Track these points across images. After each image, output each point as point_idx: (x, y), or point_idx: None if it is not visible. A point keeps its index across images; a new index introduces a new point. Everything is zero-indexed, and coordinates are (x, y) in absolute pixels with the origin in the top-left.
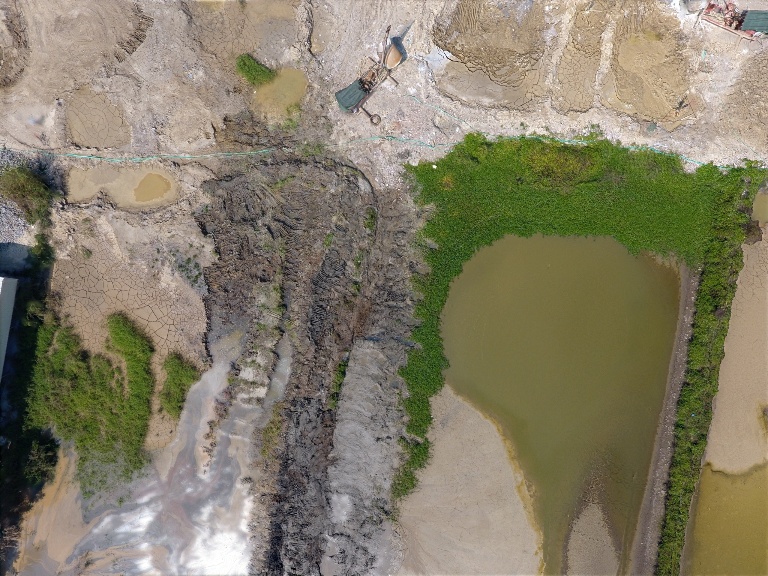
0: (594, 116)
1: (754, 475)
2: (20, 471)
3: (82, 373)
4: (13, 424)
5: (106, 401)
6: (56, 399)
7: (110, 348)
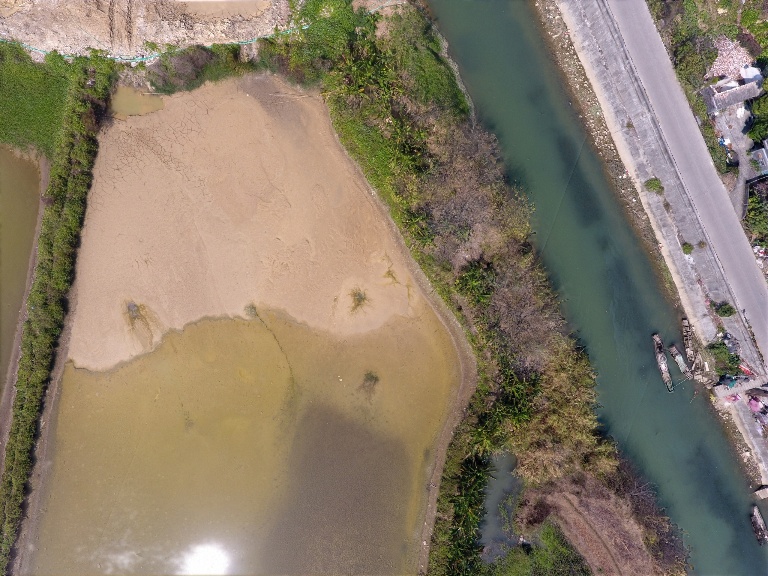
0: None
1: (120, 372)
2: None
3: None
4: None
5: None
6: None
7: None
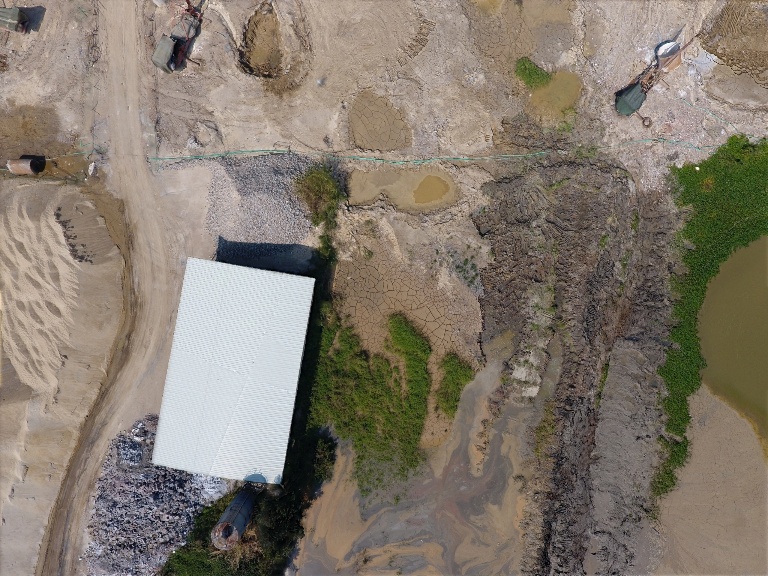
0: None
1: None
2: (302, 469)
3: (364, 372)
4: (298, 423)
5: (384, 400)
6: (338, 398)
7: (389, 348)
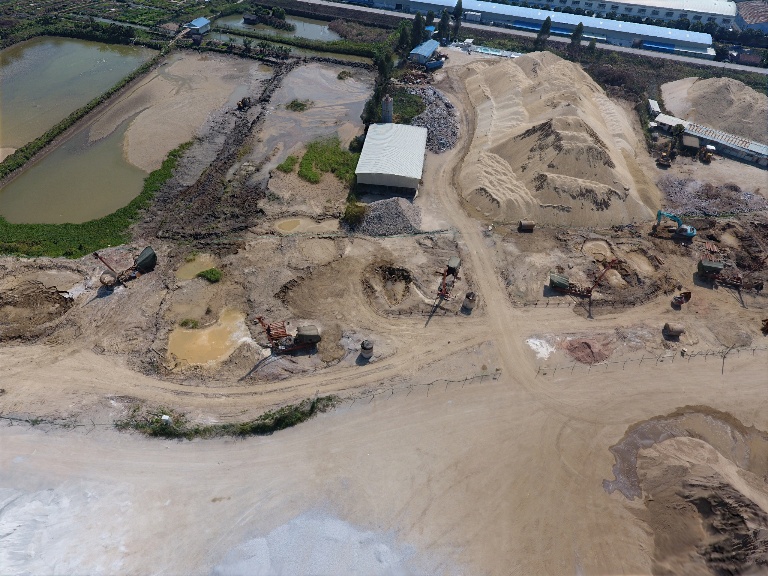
0: None
1: None
2: None
3: None
4: None
5: None
6: None
7: (320, 174)
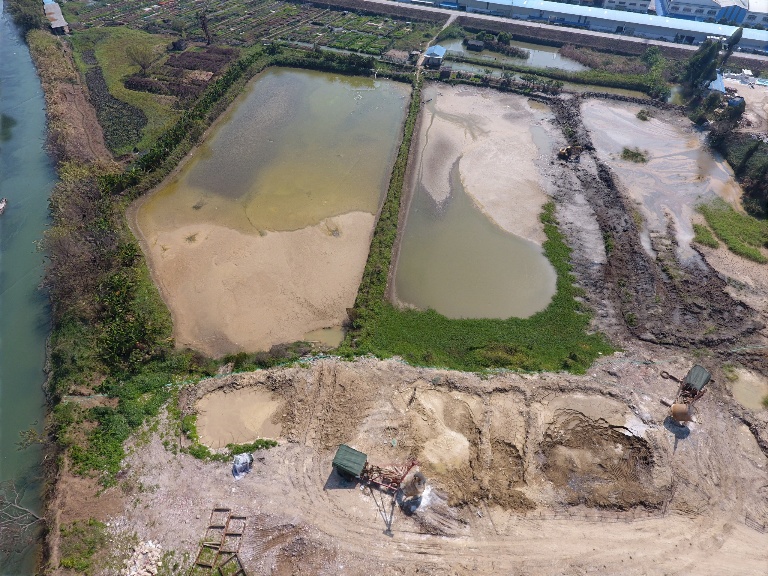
0: (488, 385)
1: (346, 211)
2: None
3: (762, 238)
4: None
5: None
6: (767, 229)
7: None
